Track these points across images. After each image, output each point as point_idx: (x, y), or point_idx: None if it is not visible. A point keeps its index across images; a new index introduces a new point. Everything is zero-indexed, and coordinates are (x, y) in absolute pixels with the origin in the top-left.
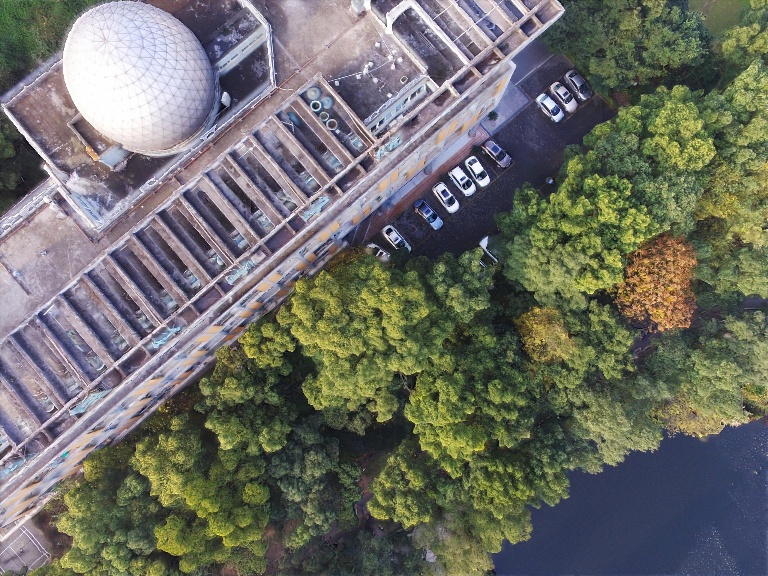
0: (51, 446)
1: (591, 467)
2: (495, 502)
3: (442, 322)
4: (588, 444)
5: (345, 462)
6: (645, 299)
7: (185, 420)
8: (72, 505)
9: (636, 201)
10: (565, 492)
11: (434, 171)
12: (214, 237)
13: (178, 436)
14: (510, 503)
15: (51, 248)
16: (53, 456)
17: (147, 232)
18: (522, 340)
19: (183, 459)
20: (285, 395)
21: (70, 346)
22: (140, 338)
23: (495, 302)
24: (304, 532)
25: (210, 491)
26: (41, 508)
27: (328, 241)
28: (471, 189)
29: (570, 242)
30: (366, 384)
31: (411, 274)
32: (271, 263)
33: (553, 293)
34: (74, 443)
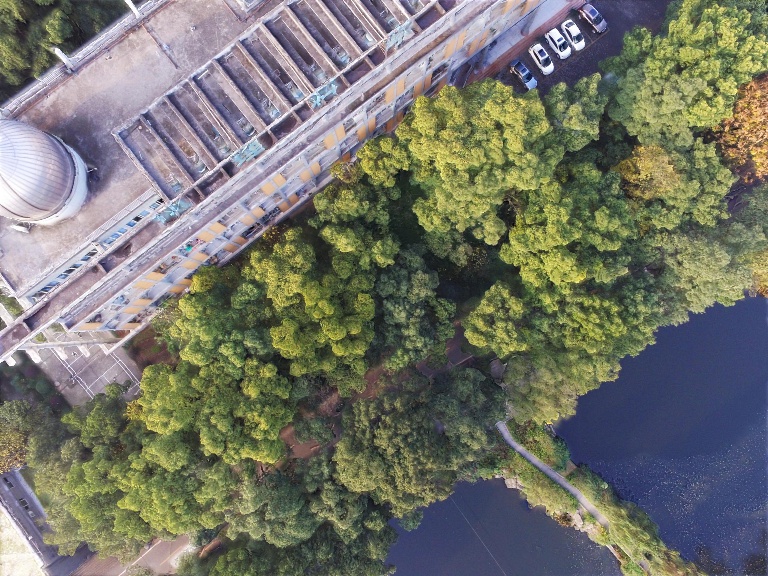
0: (203, 202)
1: (677, 317)
2: (587, 339)
3: (556, 146)
4: (675, 294)
5: (441, 297)
6: (752, 136)
7: (299, 232)
8: (190, 305)
9: (752, 34)
10: (652, 337)
11: (530, 33)
12: (366, 11)
13: (294, 244)
14: (604, 338)
15: (200, 25)
16: (187, 237)
17: (299, 6)
18: (626, 177)
19: (302, 261)
20: (394, 217)
21: (223, 110)
22: (291, 105)
23: (594, 149)
24: (405, 354)
25: (327, 293)
26: (145, 325)
27: (444, 67)
28: (566, 52)
29: (687, 70)
30: (482, 198)
31: (533, 90)
32: (403, 64)
33: (658, 133)
34: (206, 228)
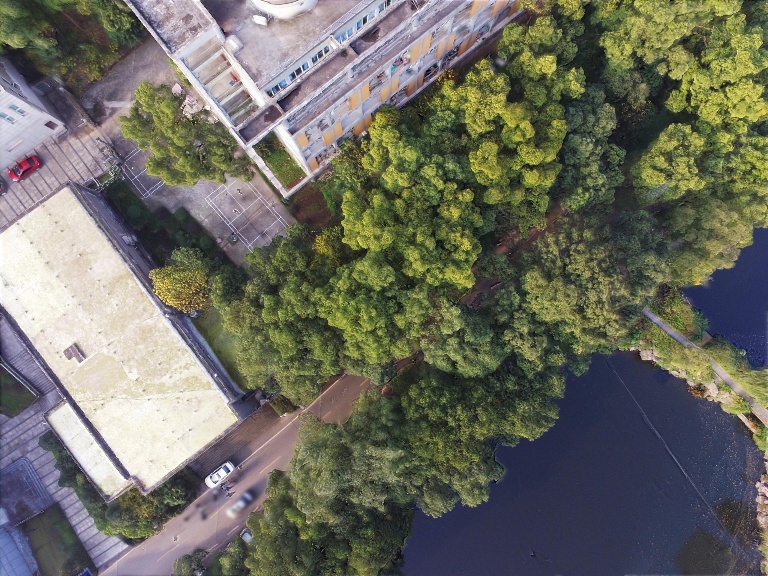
0: None
1: None
2: (759, 181)
3: None
4: None
5: (612, 143)
6: None
7: (491, 62)
8: (388, 130)
9: None
10: None
11: None
12: None
13: None
14: None
15: None
16: (406, 45)
17: None
18: None
19: (503, 84)
20: (580, 52)
21: None
22: None
23: None
24: (585, 192)
25: (528, 115)
26: (322, 169)
27: None
28: None
29: None
30: (680, 22)
31: None
32: None
33: None
34: (422, 38)
